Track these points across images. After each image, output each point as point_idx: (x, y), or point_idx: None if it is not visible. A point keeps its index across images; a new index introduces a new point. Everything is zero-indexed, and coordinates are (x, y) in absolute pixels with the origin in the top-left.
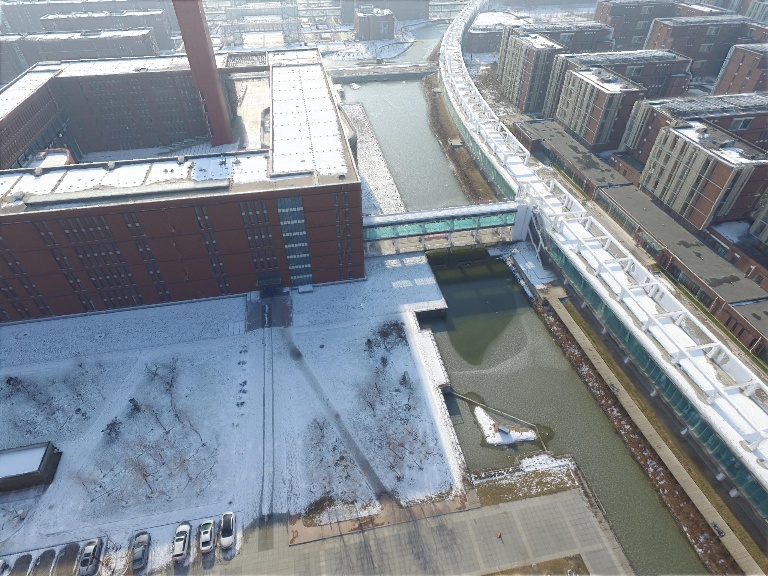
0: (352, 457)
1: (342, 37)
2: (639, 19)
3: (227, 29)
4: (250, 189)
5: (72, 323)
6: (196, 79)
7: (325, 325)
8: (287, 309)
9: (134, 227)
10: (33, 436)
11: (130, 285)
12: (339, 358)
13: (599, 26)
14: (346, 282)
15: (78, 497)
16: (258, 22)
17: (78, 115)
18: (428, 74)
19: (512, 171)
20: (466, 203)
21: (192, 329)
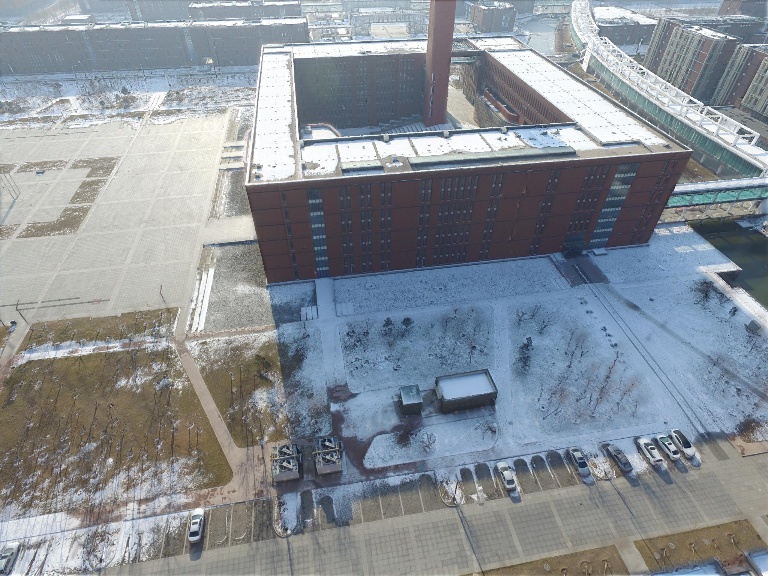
0: (746, 389)
1: (461, 29)
2: (765, 14)
3: (358, 19)
4: (596, 155)
5: (406, 277)
6: (433, 61)
7: (641, 282)
8: (596, 268)
9: (496, 187)
10: (449, 367)
11: (463, 243)
12: (675, 309)
13: (753, 19)
14: (632, 247)
15: (528, 416)
16: (386, 13)
17: (305, 95)
18: (567, 65)
19: (744, 150)
20: (686, 181)
21: (520, 284)
